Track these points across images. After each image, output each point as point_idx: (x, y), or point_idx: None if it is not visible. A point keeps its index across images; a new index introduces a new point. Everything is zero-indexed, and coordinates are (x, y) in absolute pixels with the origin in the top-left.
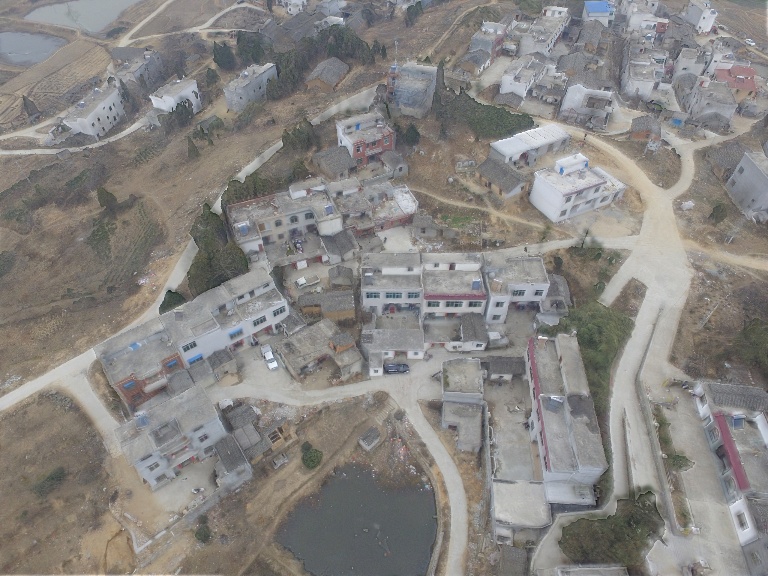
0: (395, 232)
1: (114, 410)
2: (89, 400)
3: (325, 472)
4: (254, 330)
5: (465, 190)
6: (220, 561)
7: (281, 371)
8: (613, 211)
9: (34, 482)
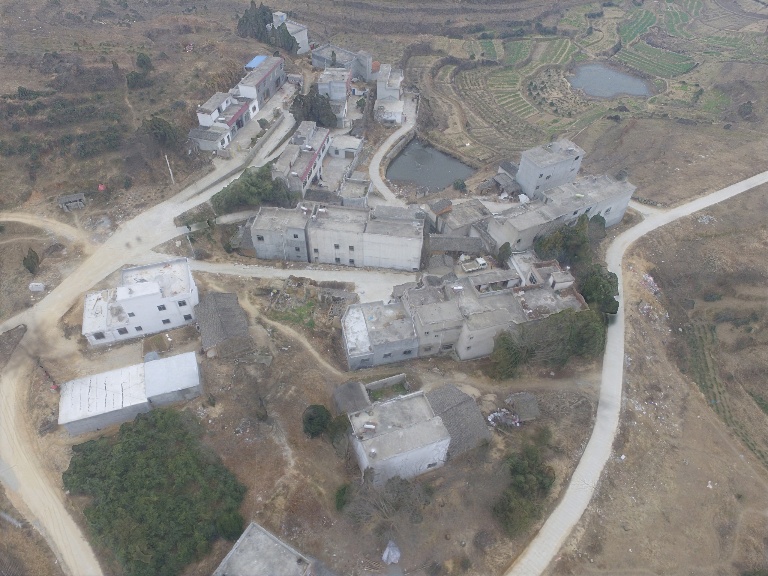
0: None
1: None
2: None
3: None
4: None
5: None
6: None
7: None
8: None
9: None
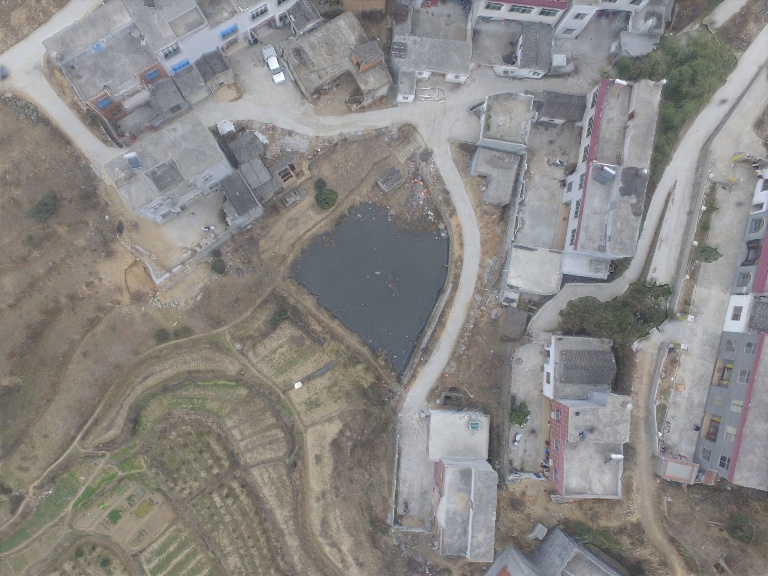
0: None
1: (92, 124)
2: (57, 108)
3: (339, 212)
4: (252, 23)
5: None
6: (238, 291)
7: (289, 86)
8: None
9: (27, 205)
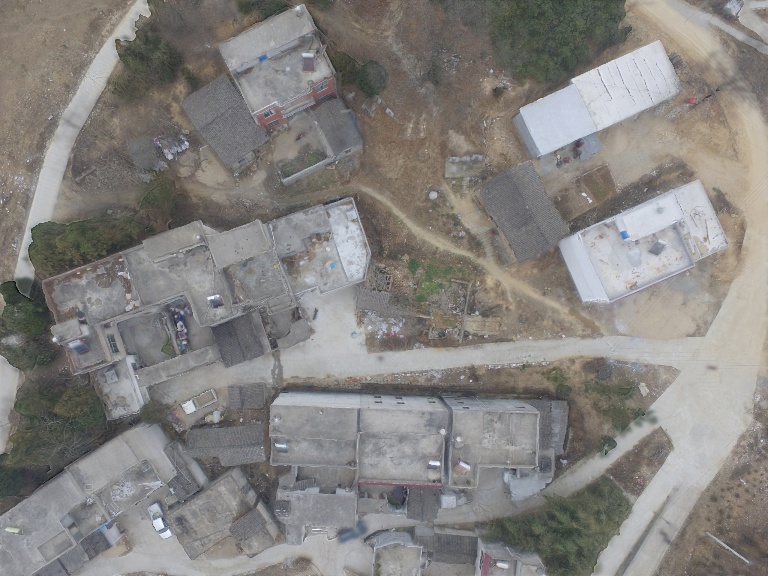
0: (332, 293)
1: None
2: None
3: None
4: None
5: (454, 222)
6: None
7: None
8: (685, 278)
9: None
